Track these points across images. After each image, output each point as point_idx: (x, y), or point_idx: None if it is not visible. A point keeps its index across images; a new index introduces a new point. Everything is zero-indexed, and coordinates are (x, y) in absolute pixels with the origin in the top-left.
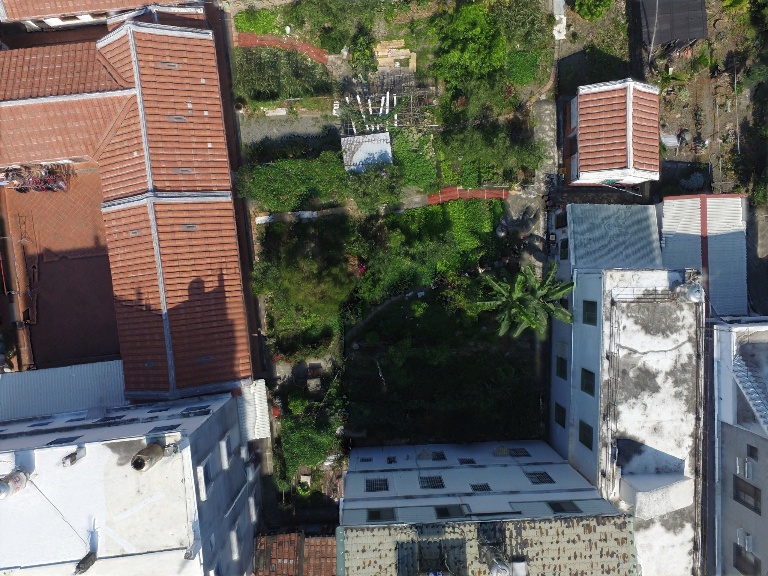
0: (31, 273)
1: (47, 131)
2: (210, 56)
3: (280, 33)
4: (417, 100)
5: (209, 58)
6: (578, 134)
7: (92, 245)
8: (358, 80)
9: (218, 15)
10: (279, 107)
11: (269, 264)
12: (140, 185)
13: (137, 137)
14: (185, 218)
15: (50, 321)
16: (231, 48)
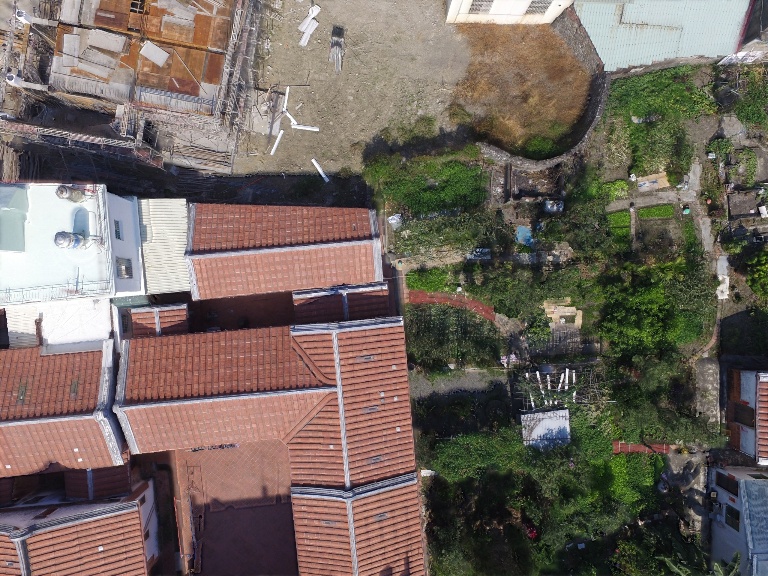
0: (197, 522)
1: (243, 420)
2: (400, 342)
3: (450, 290)
4: (595, 376)
5: (399, 344)
6: (757, 419)
7: (258, 495)
8: (524, 336)
9: (390, 273)
10: (448, 363)
11: (457, 552)
12: (335, 477)
13: (334, 432)
14: (377, 509)
15: (214, 570)
16: (402, 304)
